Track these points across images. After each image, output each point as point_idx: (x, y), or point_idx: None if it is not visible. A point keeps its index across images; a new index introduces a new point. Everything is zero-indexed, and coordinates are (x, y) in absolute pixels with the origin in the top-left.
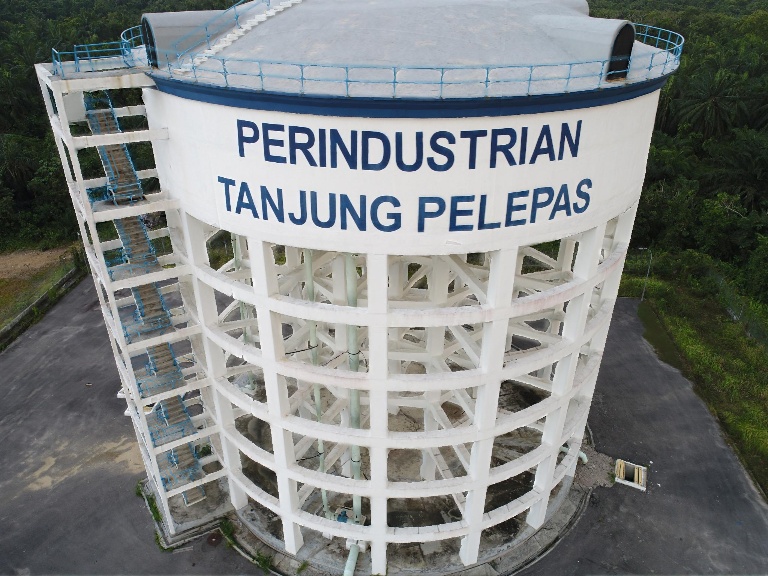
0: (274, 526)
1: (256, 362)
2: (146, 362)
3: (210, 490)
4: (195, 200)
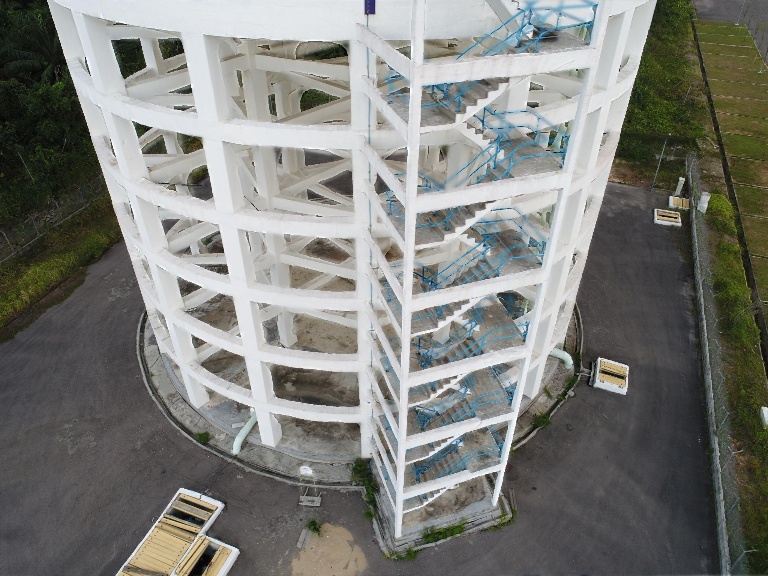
0: None
1: (578, 187)
2: (59, 574)
3: (436, 462)
4: None
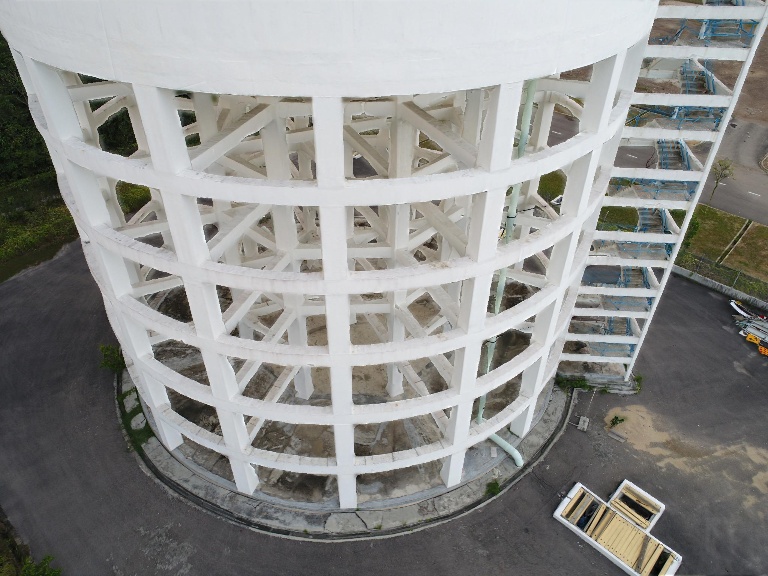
0: (522, 292)
1: None
2: None
3: None
4: None
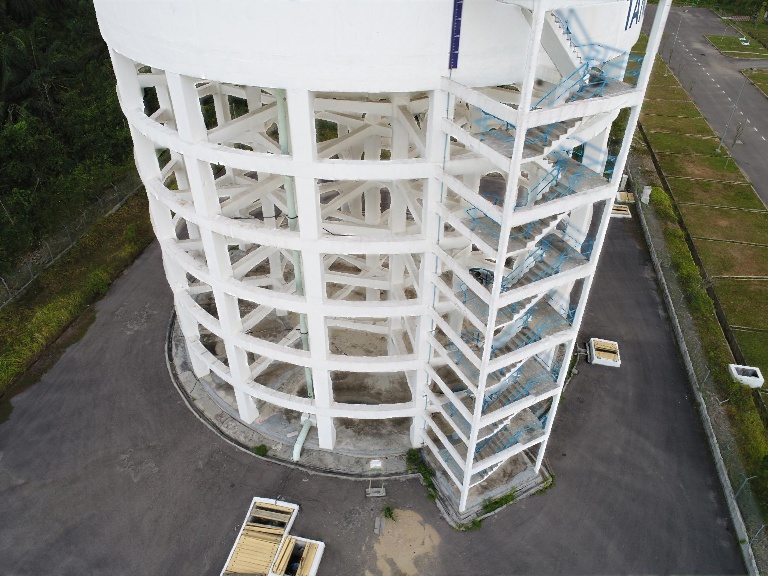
0: None
1: None
2: None
3: (478, 443)
4: (598, 42)
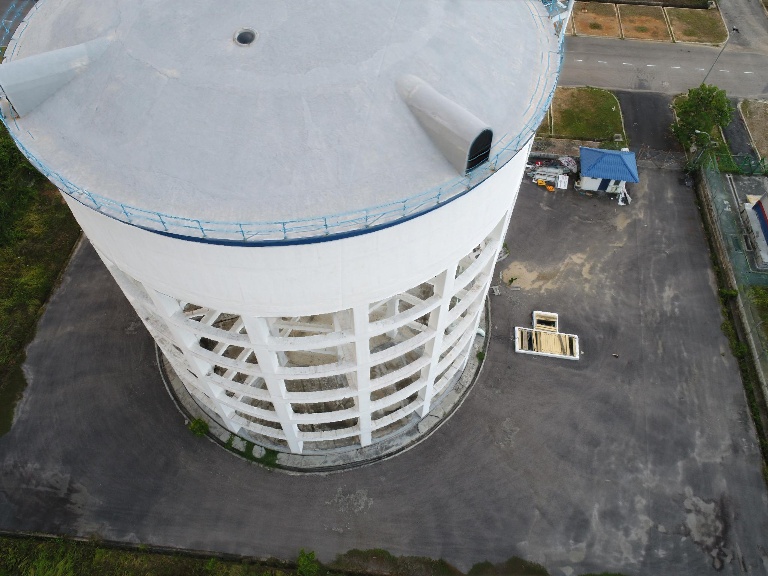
0: None
1: None
2: (579, 387)
3: None
4: None
